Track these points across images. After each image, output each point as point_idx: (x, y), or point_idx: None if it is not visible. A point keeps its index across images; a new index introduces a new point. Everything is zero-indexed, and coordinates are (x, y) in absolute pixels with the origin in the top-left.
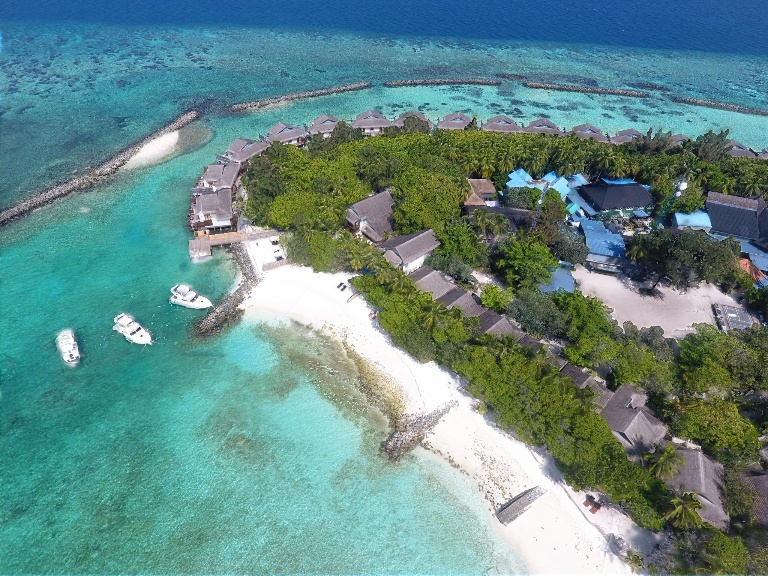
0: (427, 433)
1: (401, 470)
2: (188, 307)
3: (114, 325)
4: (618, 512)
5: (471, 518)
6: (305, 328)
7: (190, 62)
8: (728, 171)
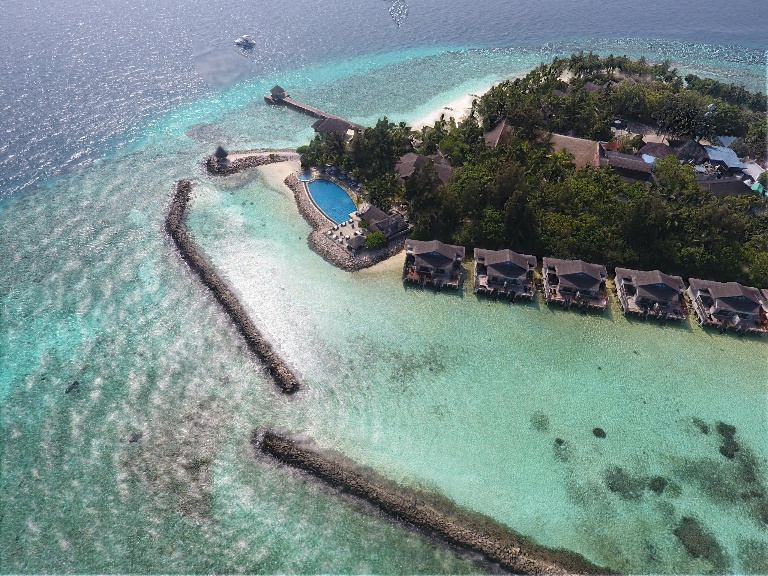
0: None
1: None
2: None
3: None
4: None
5: None
6: None
7: None
8: None
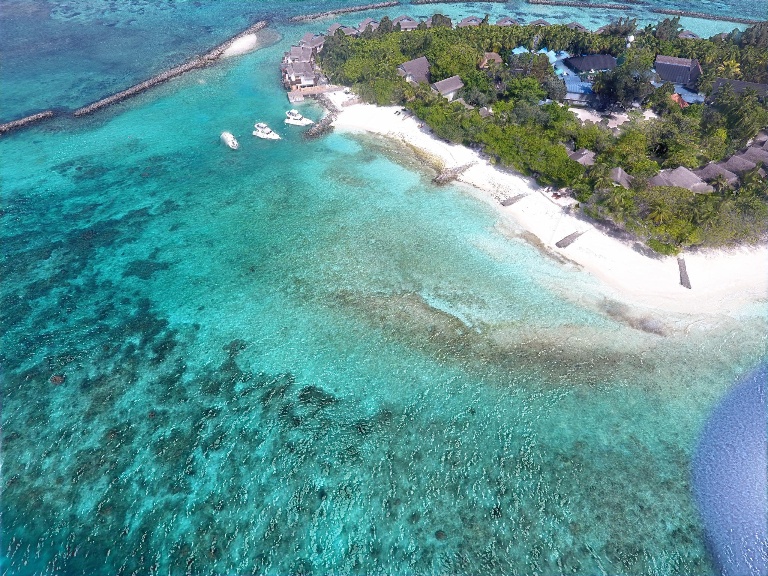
0: (459, 175)
1: (445, 189)
2: (297, 124)
3: (254, 131)
4: (571, 199)
5: (487, 205)
6: (376, 134)
7: None
8: (676, 45)
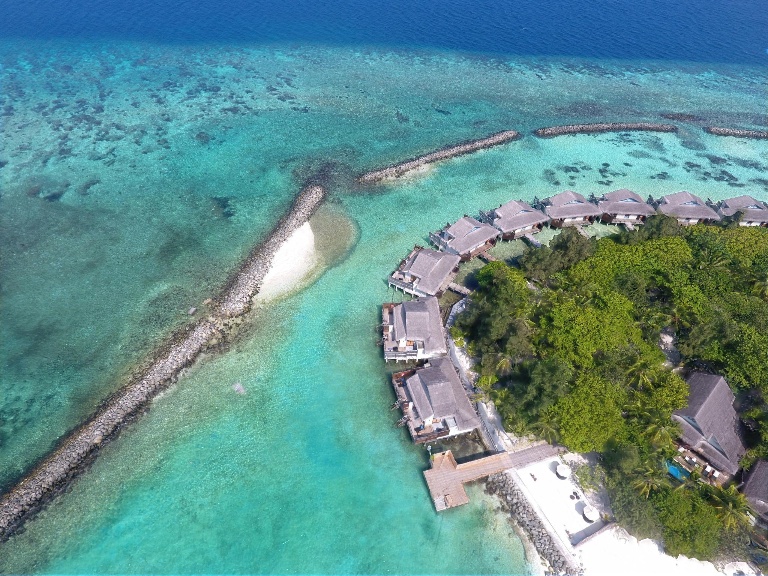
0: None
1: None
2: None
3: None
4: None
5: None
6: None
7: (277, 101)
8: None
